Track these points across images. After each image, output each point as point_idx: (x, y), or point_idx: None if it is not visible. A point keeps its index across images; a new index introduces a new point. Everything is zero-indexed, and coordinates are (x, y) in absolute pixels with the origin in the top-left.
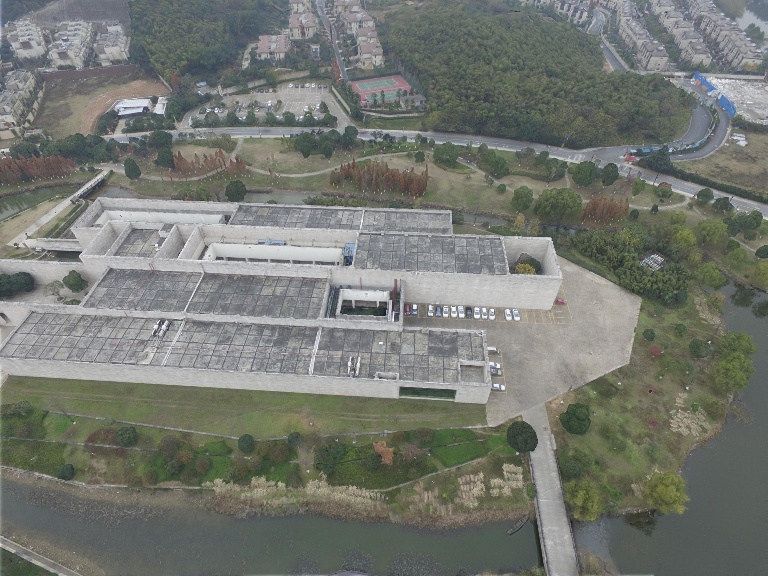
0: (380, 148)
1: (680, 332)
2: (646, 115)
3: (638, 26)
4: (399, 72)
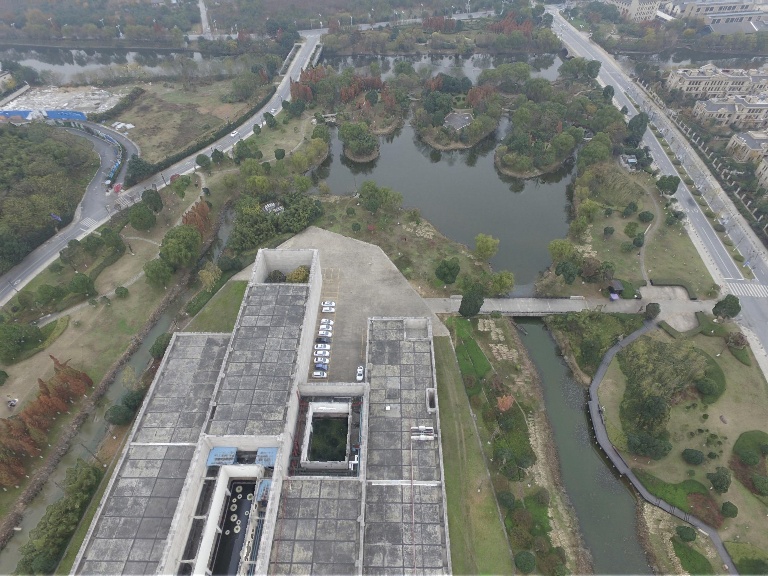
0: None
1: (353, 212)
2: (65, 153)
3: None
4: None
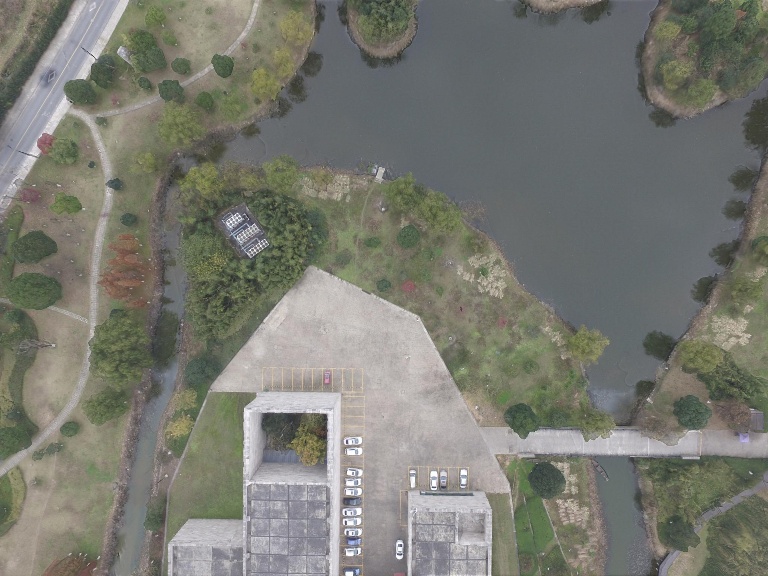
0: None
1: None
2: None
3: None
4: None
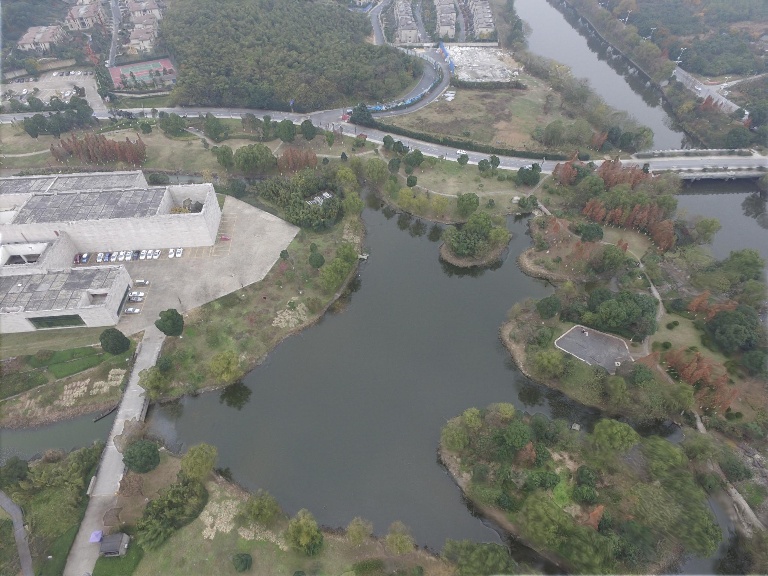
0: (119, 125)
1: (312, 250)
2: (362, 79)
3: (402, 4)
4: (167, 55)
